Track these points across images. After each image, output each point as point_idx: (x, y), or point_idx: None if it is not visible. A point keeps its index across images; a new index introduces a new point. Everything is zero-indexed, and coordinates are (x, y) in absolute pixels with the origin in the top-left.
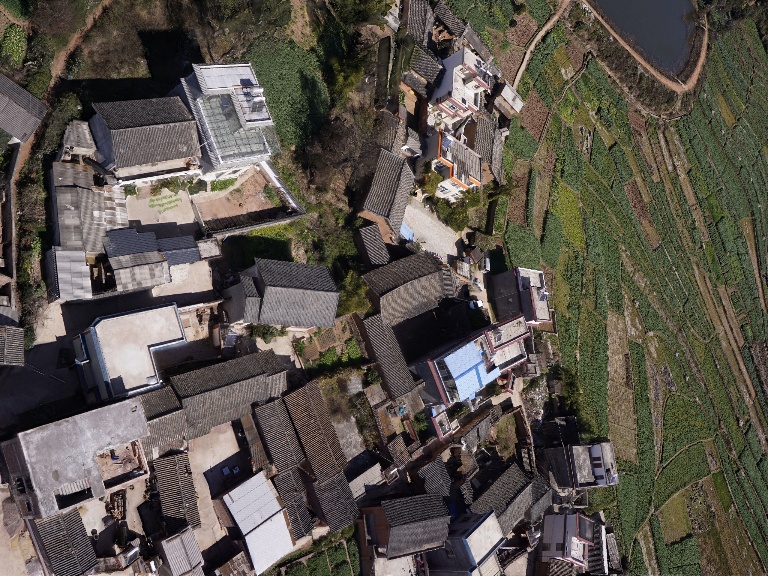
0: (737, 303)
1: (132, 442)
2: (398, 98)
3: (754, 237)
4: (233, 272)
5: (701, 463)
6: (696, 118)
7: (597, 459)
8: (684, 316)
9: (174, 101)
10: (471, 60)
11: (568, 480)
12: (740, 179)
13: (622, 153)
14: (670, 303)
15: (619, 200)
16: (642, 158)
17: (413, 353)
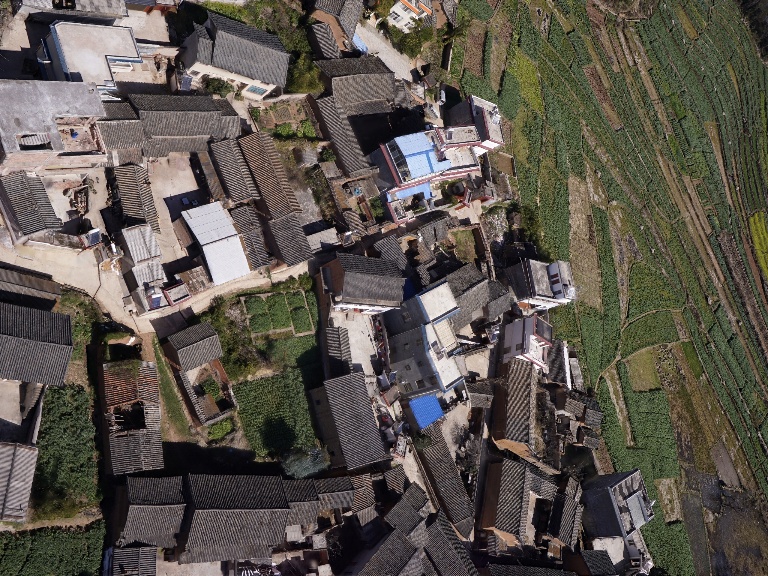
0: (703, 194)
1: (91, 127)
2: None
3: (719, 141)
4: (189, 34)
5: (669, 329)
6: (656, 24)
7: (555, 276)
8: (648, 195)
9: None
10: None
11: (526, 291)
12: (703, 87)
13: (581, 40)
14: (633, 180)
15: (578, 79)
16: (601, 48)
17: (369, 152)
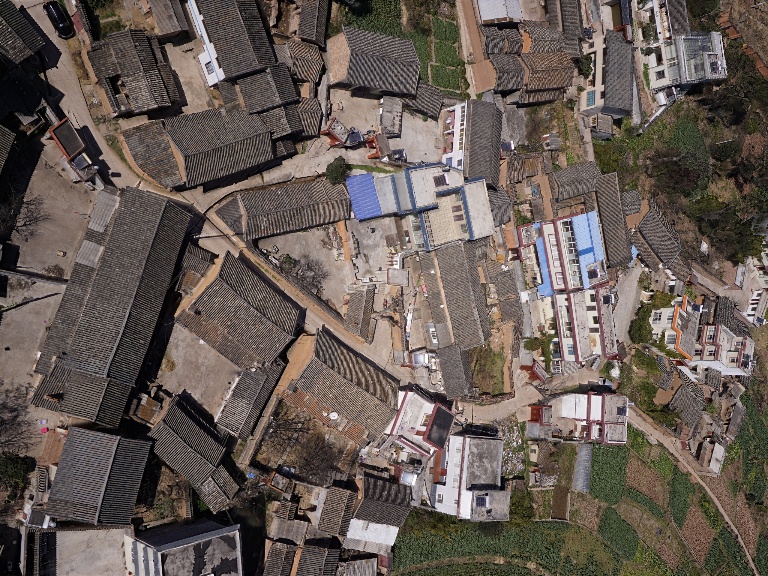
0: None
1: None
2: (698, 282)
3: None
4: None
5: None
6: None
7: None
8: None
9: None
10: (749, 351)
11: None
12: None
13: None
14: None
15: None
16: None
17: None
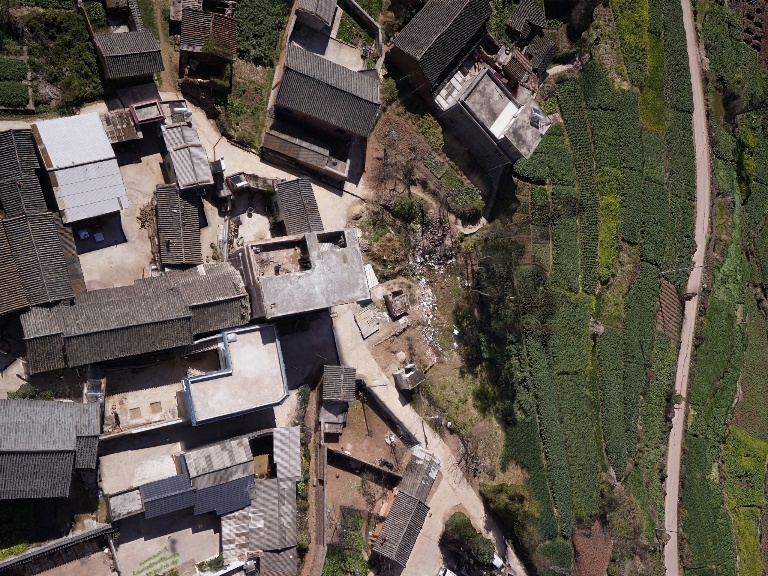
0: None
1: None
2: None
3: None
4: None
5: None
6: None
7: None
8: None
9: None
10: None
11: None
12: None
13: None
14: None
15: None
16: None
17: None
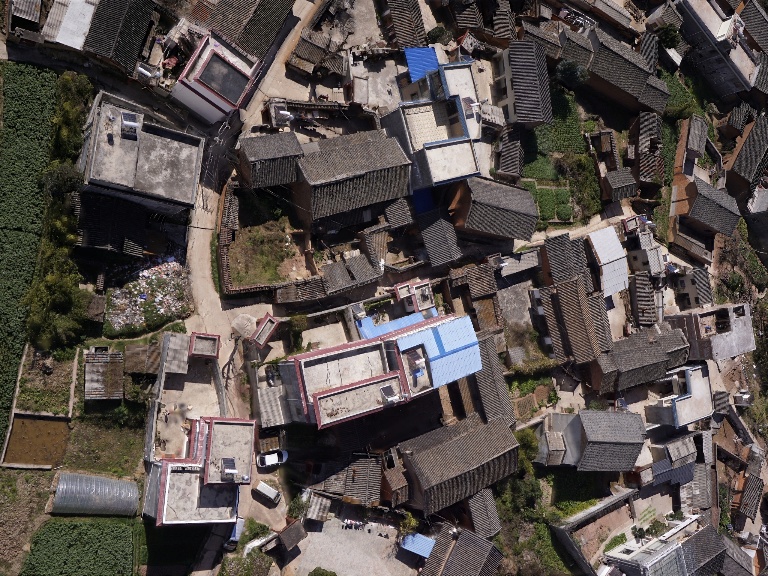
0: None
1: None
2: None
3: None
4: None
5: None
6: None
7: None
8: None
9: None
10: None
11: None
12: None
13: None
14: None
15: None
16: None
17: None
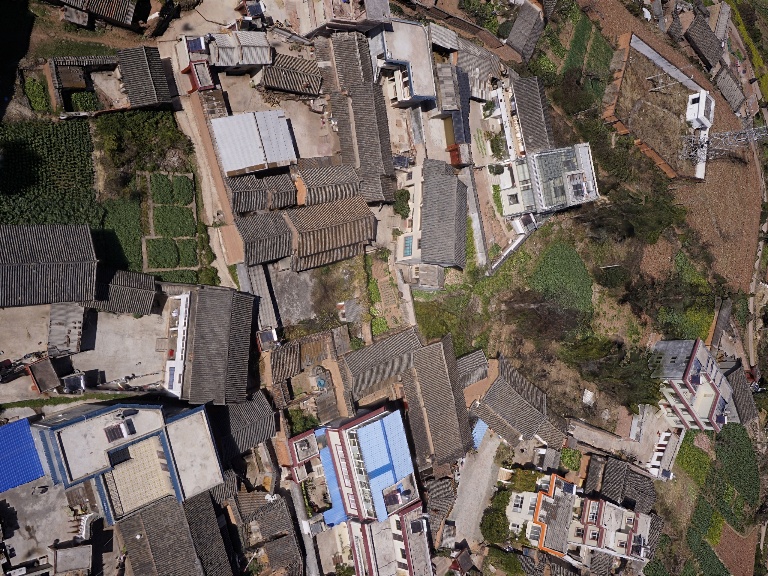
0: None
1: None
2: (580, 443)
3: None
4: None
5: None
6: None
7: None
8: None
9: (554, 145)
10: (643, 529)
11: None
12: None
13: None
14: None
15: None
16: None
17: None
